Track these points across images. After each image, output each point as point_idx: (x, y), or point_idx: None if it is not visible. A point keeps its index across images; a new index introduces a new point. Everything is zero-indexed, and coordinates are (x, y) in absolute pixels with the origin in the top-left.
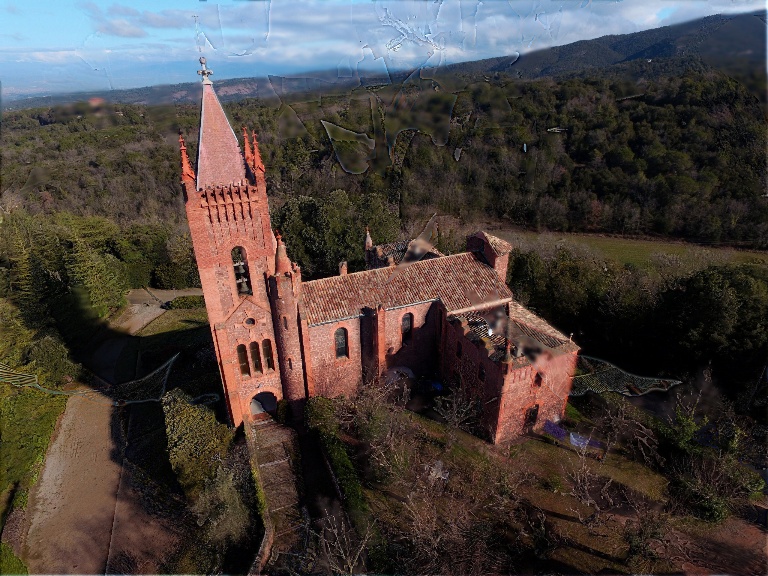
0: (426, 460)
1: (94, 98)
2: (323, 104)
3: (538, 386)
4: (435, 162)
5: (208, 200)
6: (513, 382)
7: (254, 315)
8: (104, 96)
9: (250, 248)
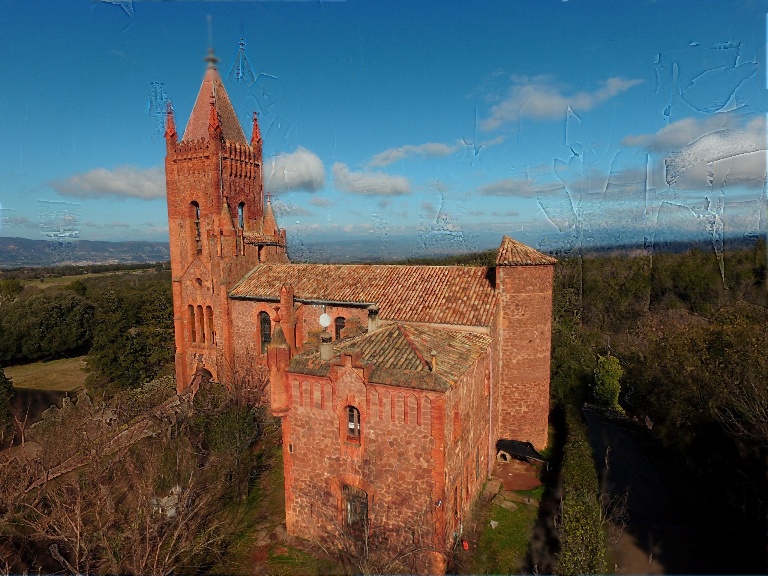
0: (205, 493)
1: (374, 190)
2: (596, 200)
3: (359, 443)
4: (700, 246)
5: (177, 154)
6: (300, 403)
7: (202, 276)
8: (381, 189)
9: (202, 204)
